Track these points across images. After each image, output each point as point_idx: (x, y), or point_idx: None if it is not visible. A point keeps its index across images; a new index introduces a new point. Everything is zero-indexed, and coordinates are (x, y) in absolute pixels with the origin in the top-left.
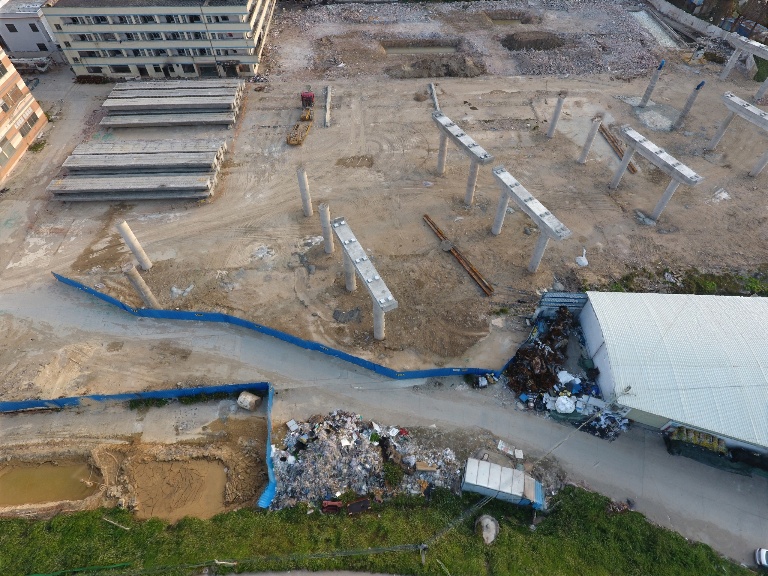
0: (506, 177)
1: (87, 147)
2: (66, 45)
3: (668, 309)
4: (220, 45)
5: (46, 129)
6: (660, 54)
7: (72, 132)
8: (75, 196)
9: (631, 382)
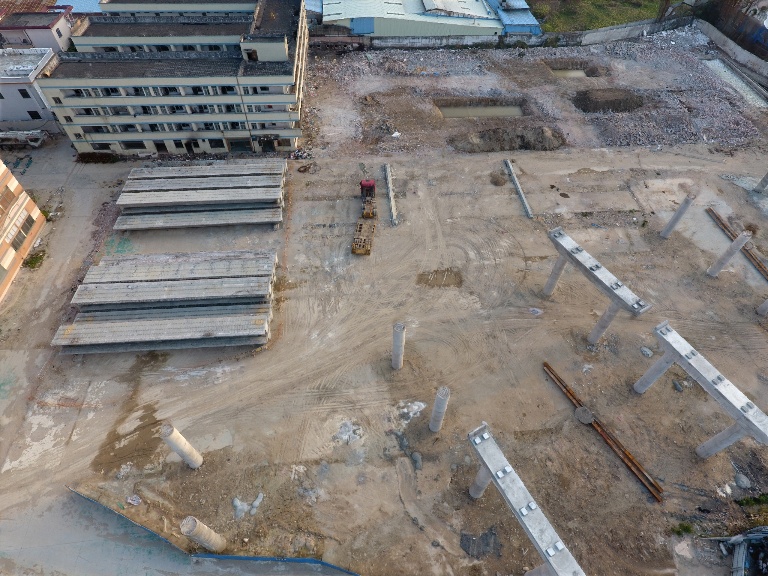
0: (676, 340)
1: (102, 271)
2: (66, 120)
3: None
4: (257, 118)
5: (44, 233)
6: (757, 119)
7: (78, 237)
8: (90, 348)
9: None
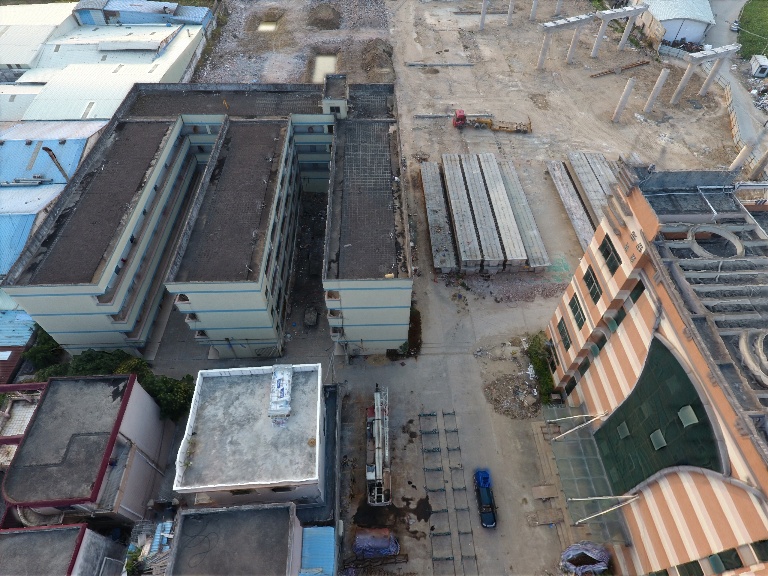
0: (607, 12)
1: None
2: None
3: (658, 5)
4: None
5: None
6: None
7: None
8: None
9: (705, 19)
